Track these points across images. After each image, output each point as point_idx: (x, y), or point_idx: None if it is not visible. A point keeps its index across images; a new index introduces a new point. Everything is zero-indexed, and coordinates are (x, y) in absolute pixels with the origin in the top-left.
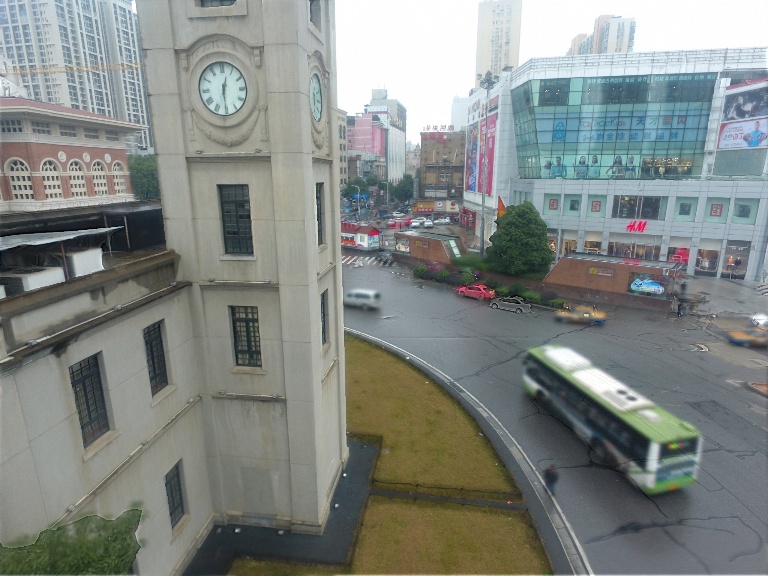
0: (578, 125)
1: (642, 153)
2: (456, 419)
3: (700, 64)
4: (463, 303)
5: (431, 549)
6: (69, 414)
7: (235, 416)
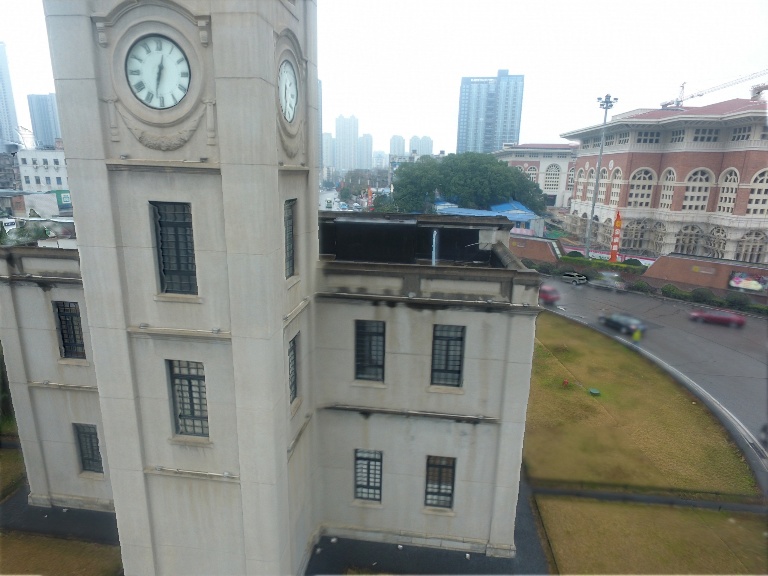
0: None
1: None
2: None
3: None
4: None
5: None
6: (51, 329)
7: None
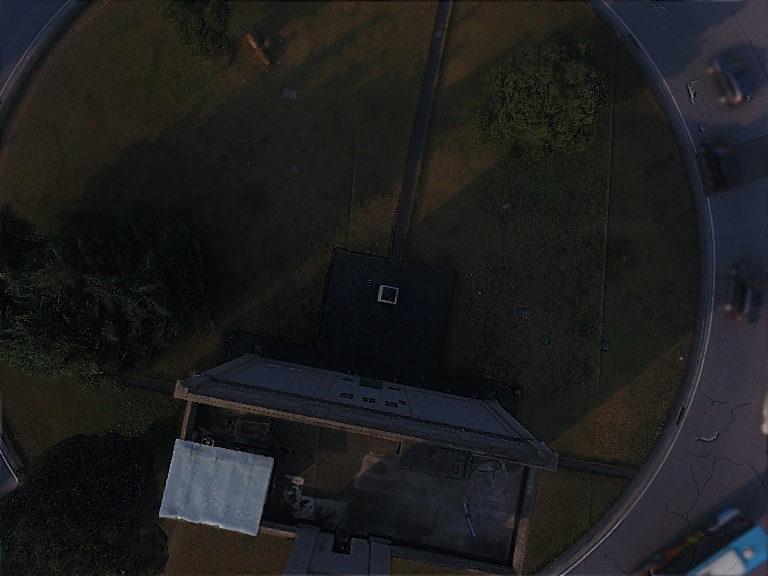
0: None
1: None
2: None
3: None
4: None
5: None
6: None
7: None
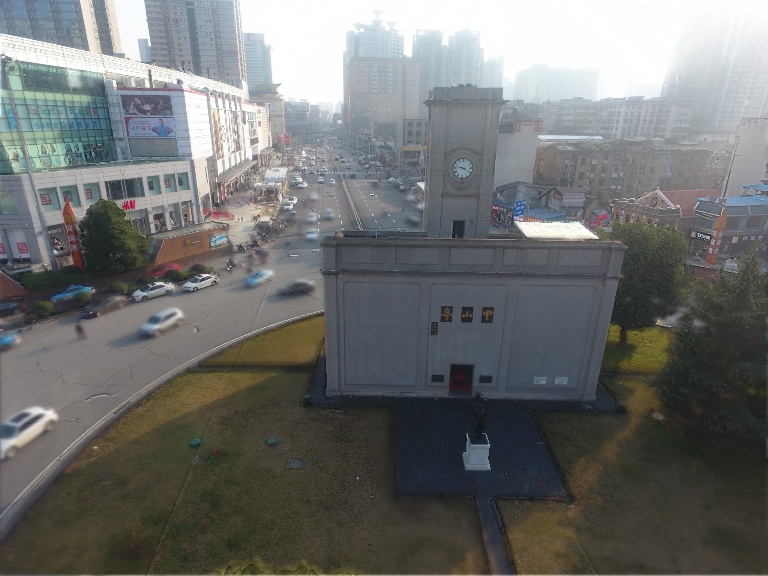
0: (27, 112)
1: (82, 140)
2: None
3: (92, 64)
4: (169, 301)
5: None
6: None
7: None
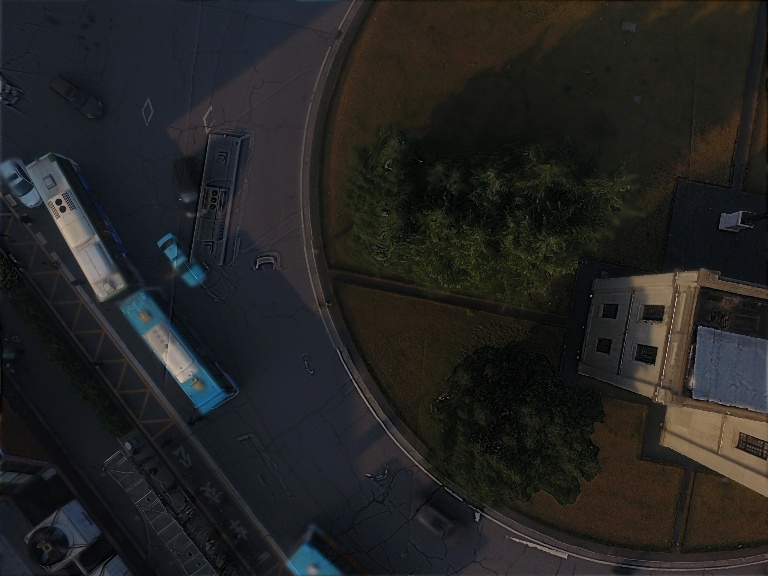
0: None
1: None
2: (759, 533)
3: None
4: None
5: (648, 498)
6: None
7: (714, 421)
